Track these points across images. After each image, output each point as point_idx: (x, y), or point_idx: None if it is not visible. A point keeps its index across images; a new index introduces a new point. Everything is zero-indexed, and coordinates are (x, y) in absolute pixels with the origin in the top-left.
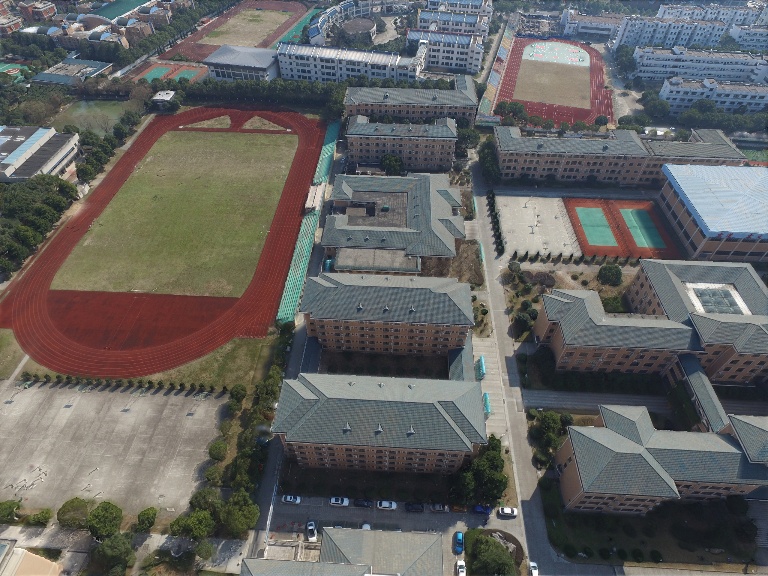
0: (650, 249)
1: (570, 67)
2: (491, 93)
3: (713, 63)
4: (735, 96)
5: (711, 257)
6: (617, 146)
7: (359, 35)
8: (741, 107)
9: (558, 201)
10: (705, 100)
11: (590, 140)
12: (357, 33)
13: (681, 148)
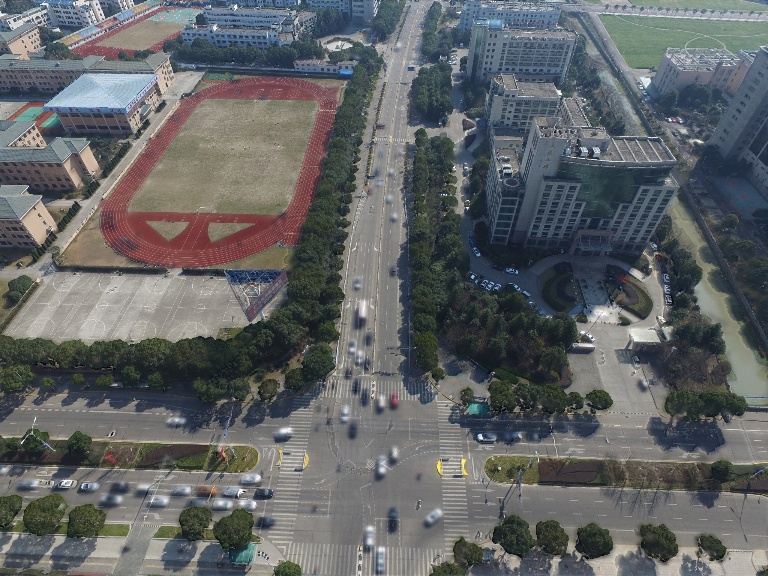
0: (44, 128)
1: (174, 25)
2: (72, 40)
3: (258, 17)
4: (229, 36)
5: (77, 131)
6: (66, 63)
7: (16, 3)
8: (230, 44)
9: (23, 104)
10: (197, 38)
11: (49, 60)
12: (14, 1)
13: (111, 64)
